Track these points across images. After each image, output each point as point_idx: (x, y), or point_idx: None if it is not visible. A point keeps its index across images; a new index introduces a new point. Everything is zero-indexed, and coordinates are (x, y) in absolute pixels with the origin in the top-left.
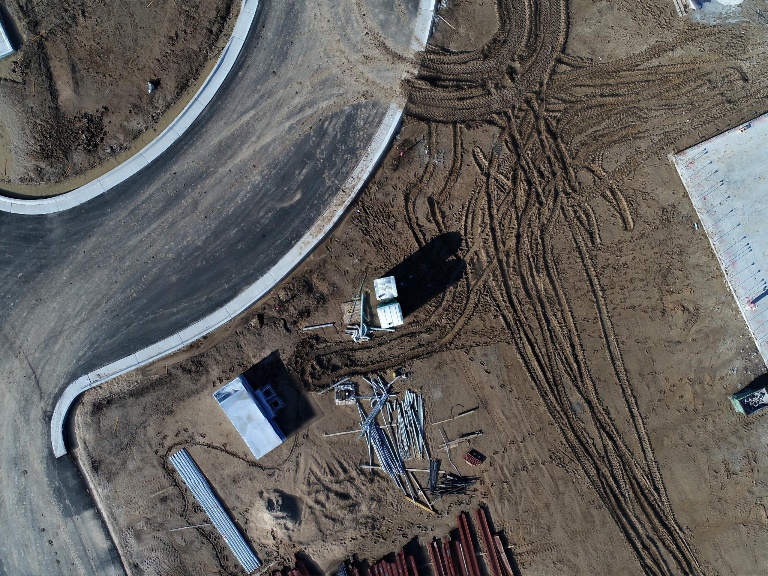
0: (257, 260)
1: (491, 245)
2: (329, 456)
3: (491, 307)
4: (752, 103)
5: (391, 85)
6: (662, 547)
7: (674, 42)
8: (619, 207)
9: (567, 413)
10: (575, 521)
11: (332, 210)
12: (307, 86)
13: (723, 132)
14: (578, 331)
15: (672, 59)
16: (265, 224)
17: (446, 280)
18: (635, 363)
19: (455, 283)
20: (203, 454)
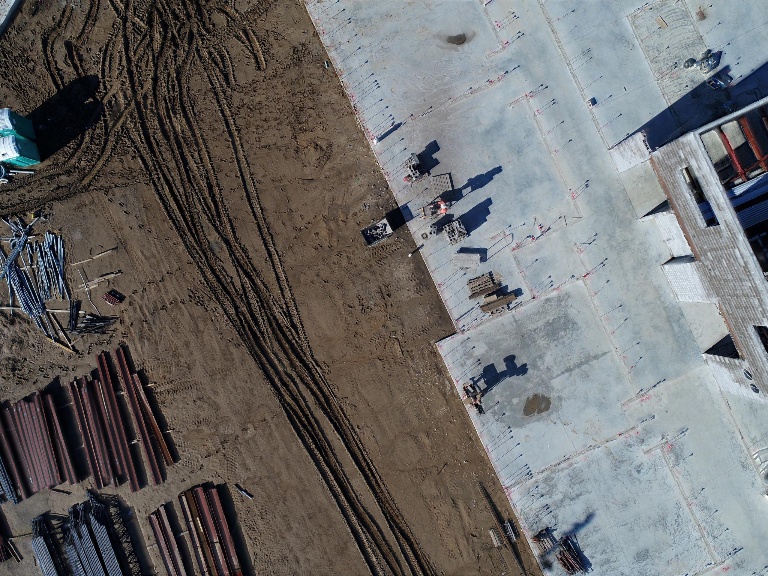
0: None
1: (128, 87)
2: None
3: (129, 148)
4: None
5: None
6: (300, 383)
7: None
8: (252, 47)
9: (206, 252)
10: (214, 359)
11: None
12: None
13: None
14: (215, 171)
15: None
16: None
17: (84, 122)
18: (271, 201)
19: (93, 125)
20: None
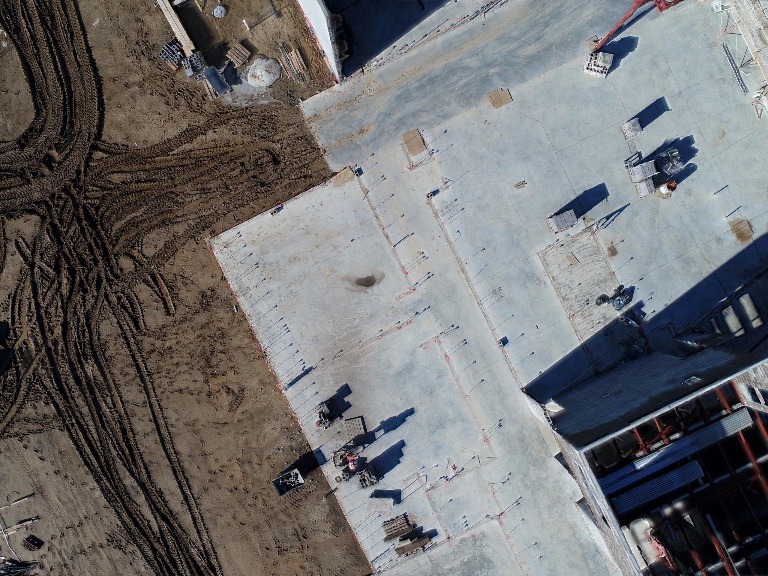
0: None
1: (39, 334)
2: None
3: (42, 395)
4: (286, 184)
5: None
6: None
7: (207, 126)
8: (161, 292)
9: (122, 496)
10: None
11: None
12: None
13: (256, 215)
14: (128, 415)
15: (205, 143)
16: None
17: None
18: (184, 445)
19: (5, 373)
20: None
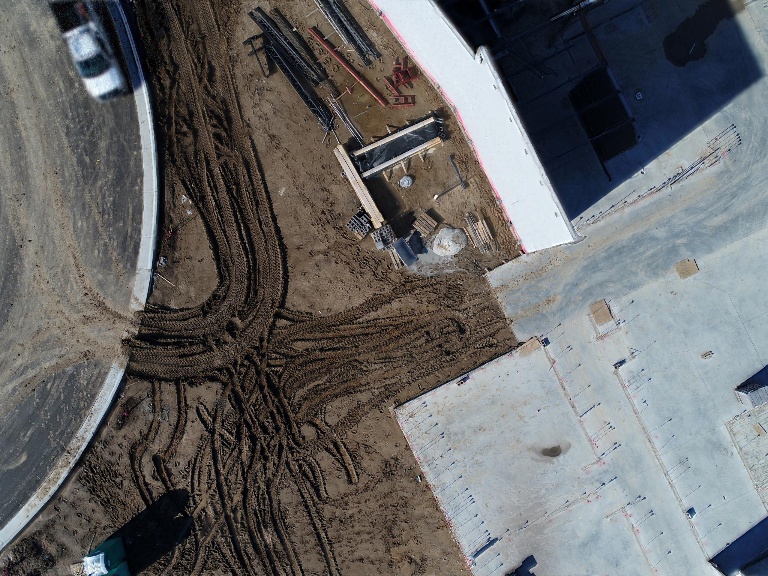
0: None
1: (218, 501)
2: None
3: (220, 563)
4: (471, 354)
5: (113, 345)
6: None
7: (392, 294)
8: (343, 460)
9: None
10: None
11: (58, 472)
12: (29, 348)
13: (442, 385)
14: None
15: (390, 312)
16: None
17: (174, 538)
18: None
19: (183, 541)
20: None
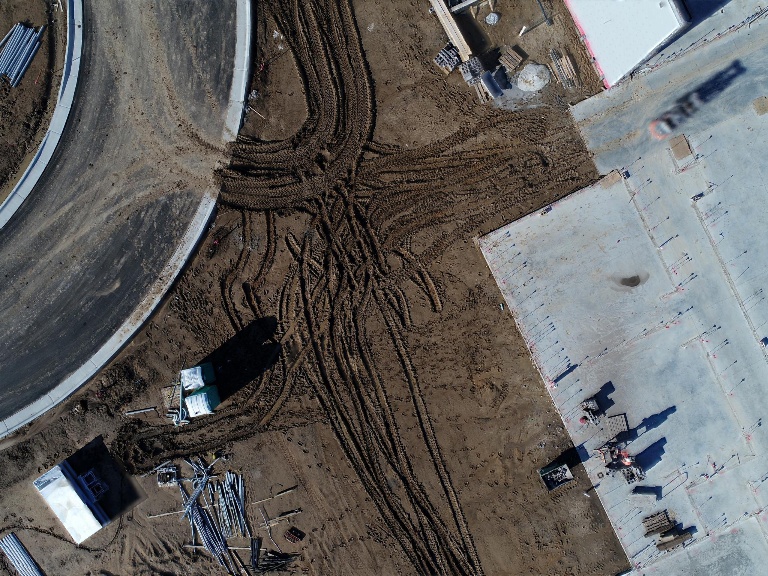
0: (79, 348)
1: (306, 328)
2: (153, 537)
3: (307, 388)
4: (553, 186)
5: (205, 175)
6: None
7: (477, 128)
8: (428, 289)
9: (383, 489)
10: None
11: (150, 298)
12: (123, 177)
13: (525, 215)
14: (392, 410)
15: (475, 145)
16: (86, 313)
17: (263, 363)
18: (447, 440)
19: (272, 366)
20: (31, 538)
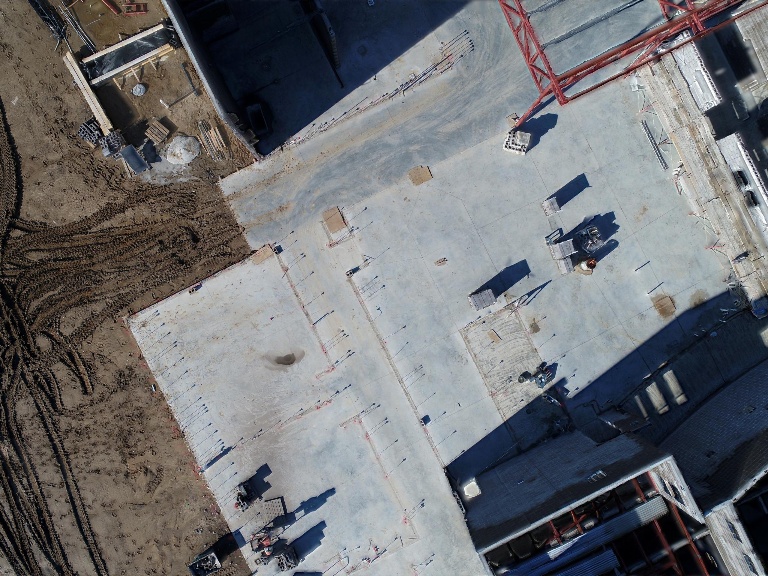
0: None
1: None
2: None
3: None
4: (205, 262)
5: None
6: None
7: (126, 203)
8: (78, 371)
9: None
10: None
11: None
12: None
13: (175, 293)
14: (45, 496)
15: (124, 221)
16: None
17: None
18: (102, 527)
19: None
20: None
